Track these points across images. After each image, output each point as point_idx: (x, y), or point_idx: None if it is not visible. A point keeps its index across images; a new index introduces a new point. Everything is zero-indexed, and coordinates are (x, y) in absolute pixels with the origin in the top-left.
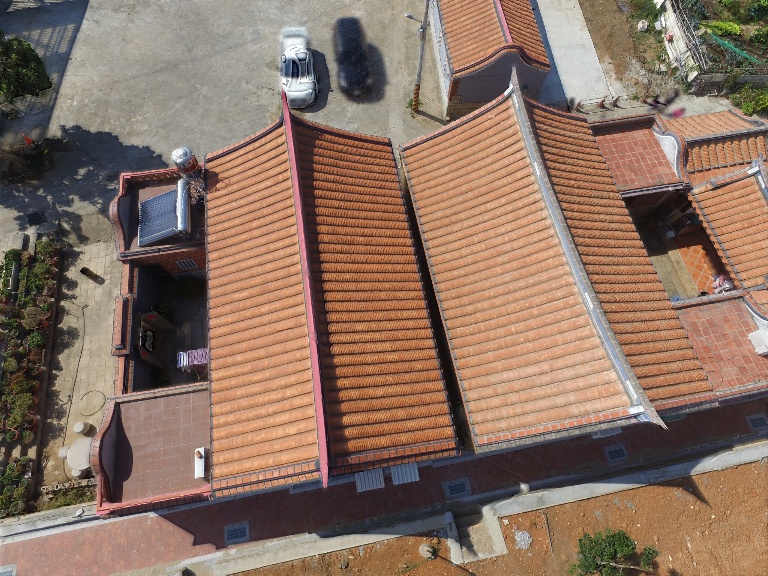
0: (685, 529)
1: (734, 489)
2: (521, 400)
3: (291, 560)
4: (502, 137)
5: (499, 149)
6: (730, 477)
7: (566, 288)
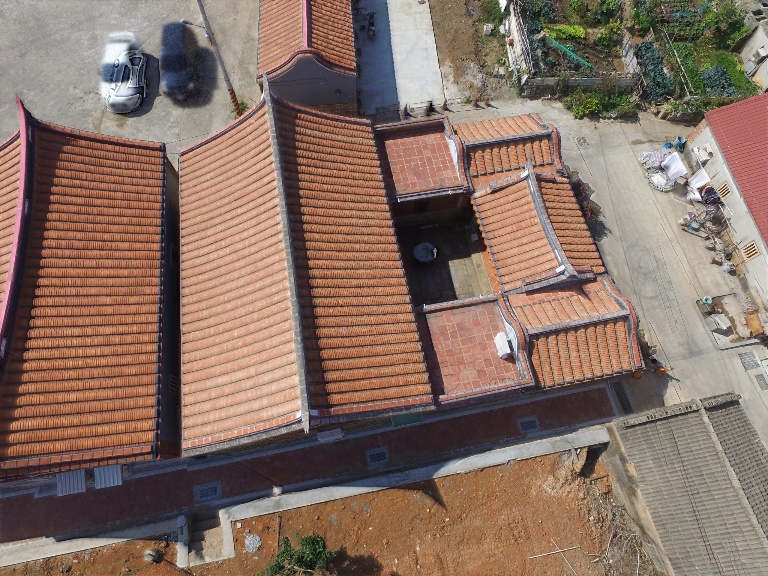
0: (417, 532)
1: (475, 492)
2: (227, 404)
3: (14, 564)
4: (258, 142)
5: (255, 154)
6: (473, 480)
7: (282, 292)
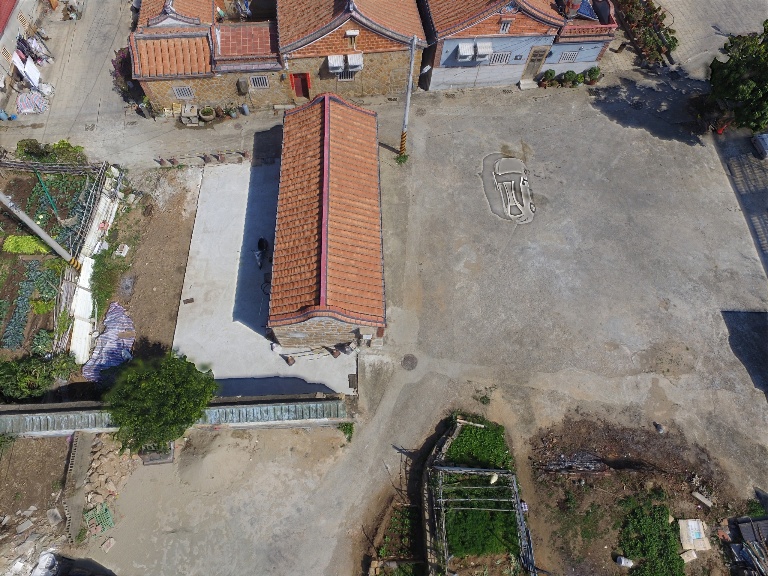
0: None
1: None
2: None
3: None
4: None
5: None
6: None
7: None
